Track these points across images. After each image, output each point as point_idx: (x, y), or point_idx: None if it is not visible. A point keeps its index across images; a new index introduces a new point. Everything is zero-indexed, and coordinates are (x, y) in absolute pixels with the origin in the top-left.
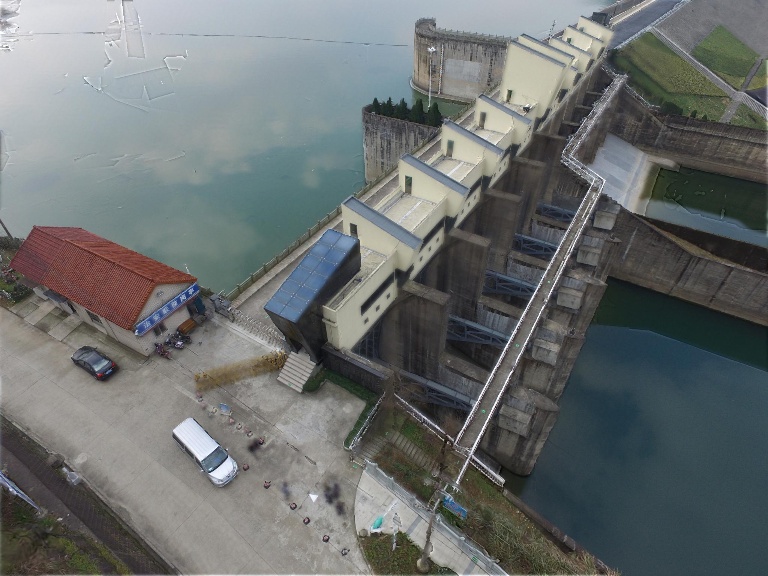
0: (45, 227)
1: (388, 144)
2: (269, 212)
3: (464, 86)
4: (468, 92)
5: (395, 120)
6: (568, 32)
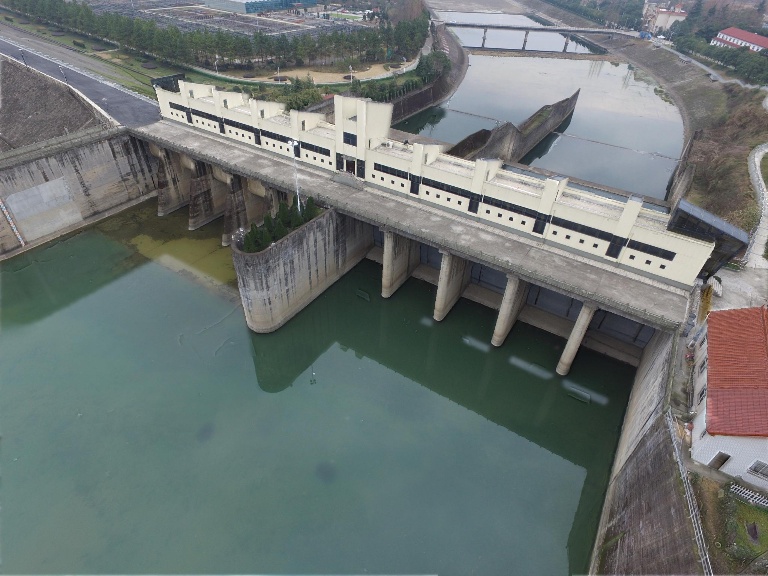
0: (765, 432)
1: (291, 265)
2: (316, 442)
3: (56, 215)
4: (66, 218)
5: (295, 233)
6: (222, 95)
